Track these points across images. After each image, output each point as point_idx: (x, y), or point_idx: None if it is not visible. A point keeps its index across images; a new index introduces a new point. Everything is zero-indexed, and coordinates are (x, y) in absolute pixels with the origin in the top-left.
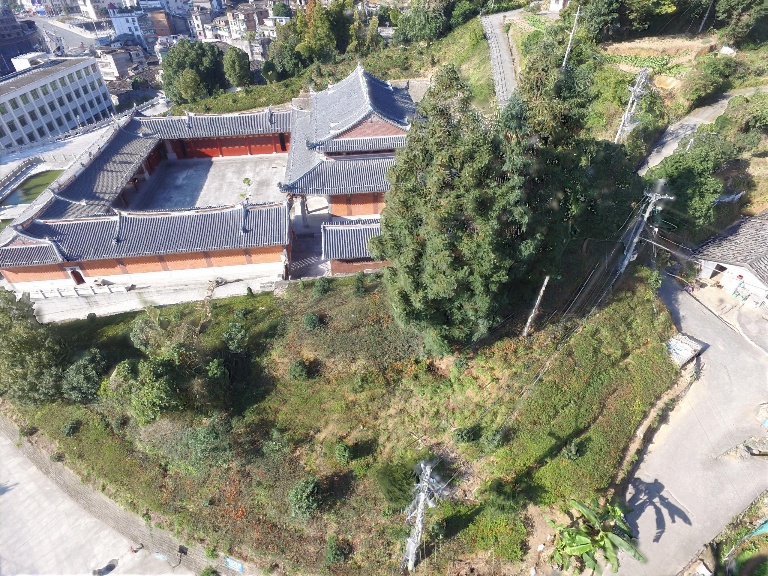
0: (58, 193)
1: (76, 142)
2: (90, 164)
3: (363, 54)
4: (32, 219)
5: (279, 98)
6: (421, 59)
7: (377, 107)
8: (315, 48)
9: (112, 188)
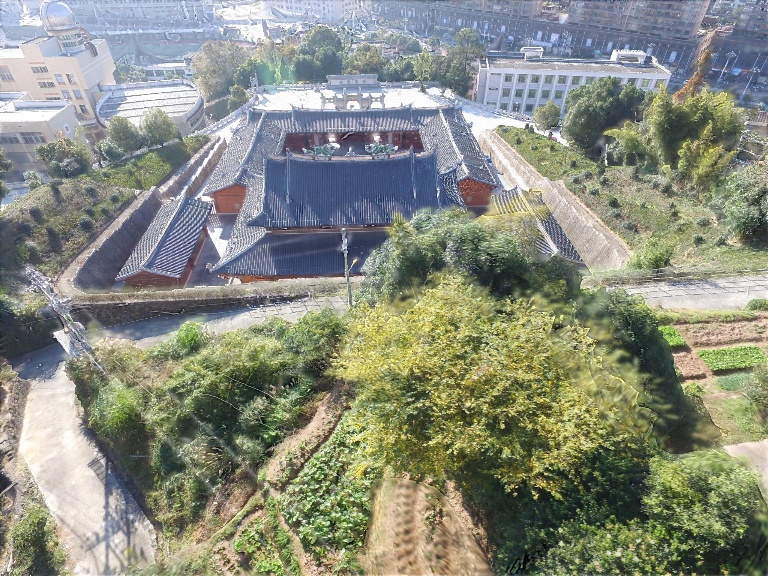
0: (297, 110)
1: (495, 119)
2: (346, 112)
3: (672, 191)
4: (263, 111)
5: (549, 171)
6: (682, 249)
7: (298, 171)
8: (650, 148)
9: (320, 128)
